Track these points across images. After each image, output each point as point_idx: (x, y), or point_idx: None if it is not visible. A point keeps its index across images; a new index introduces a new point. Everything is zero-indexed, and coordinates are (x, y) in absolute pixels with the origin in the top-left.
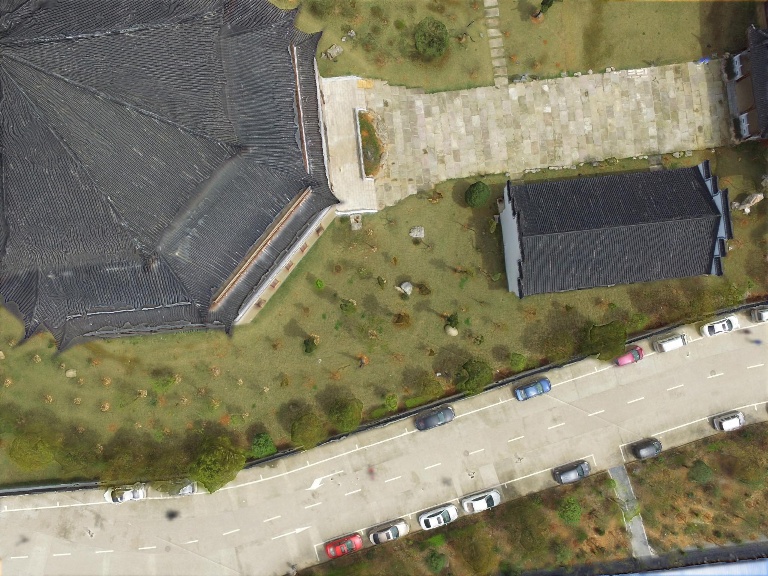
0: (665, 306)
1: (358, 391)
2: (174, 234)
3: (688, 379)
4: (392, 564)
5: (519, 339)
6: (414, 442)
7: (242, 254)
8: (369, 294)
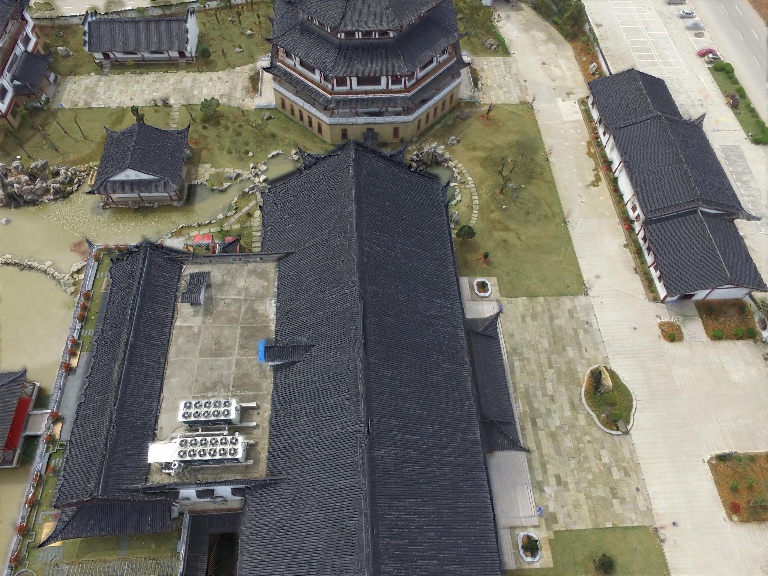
0: None
1: None
2: None
3: (124, 4)
4: None
5: (200, 18)
6: None
7: None
8: (269, 33)
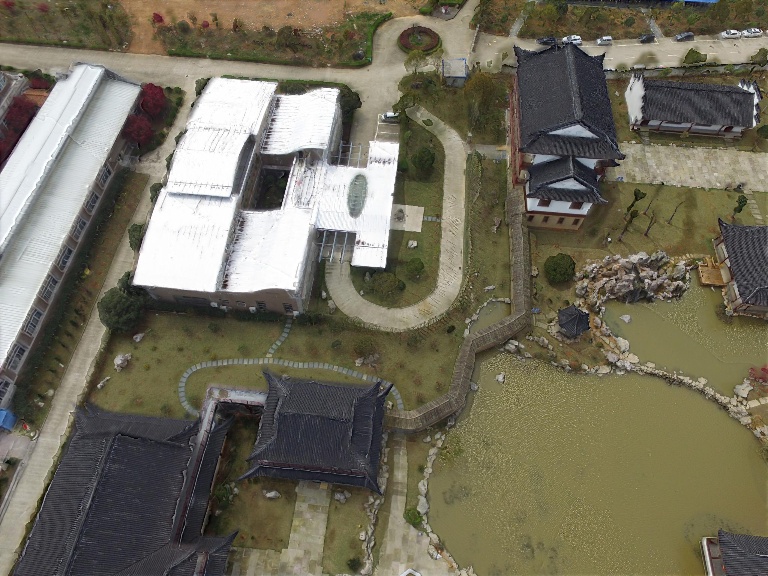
0: None
1: None
2: None
3: None
4: None
5: None
6: None
7: None
8: None
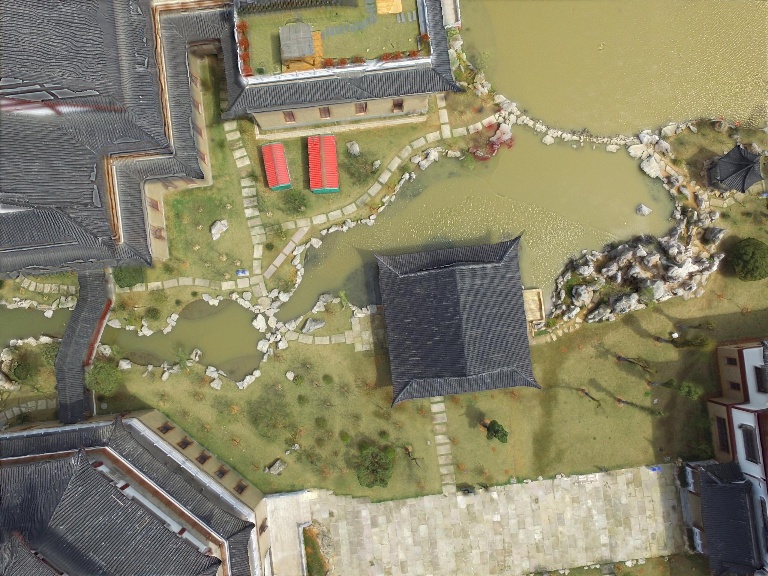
0: None
1: None
2: None
3: None
4: None
5: None
6: None
7: None
8: None
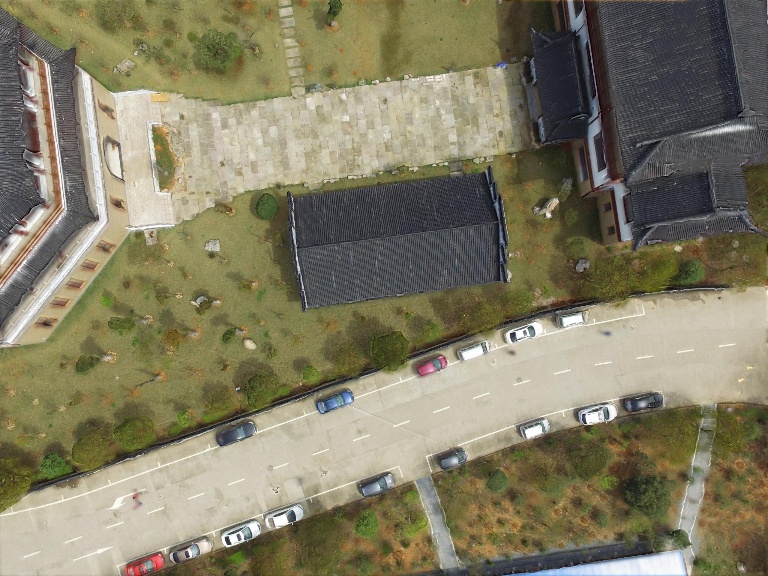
0: (468, 314)
1: (157, 408)
2: None
3: (494, 387)
4: None
5: (320, 351)
6: (217, 458)
7: None
8: (165, 309)
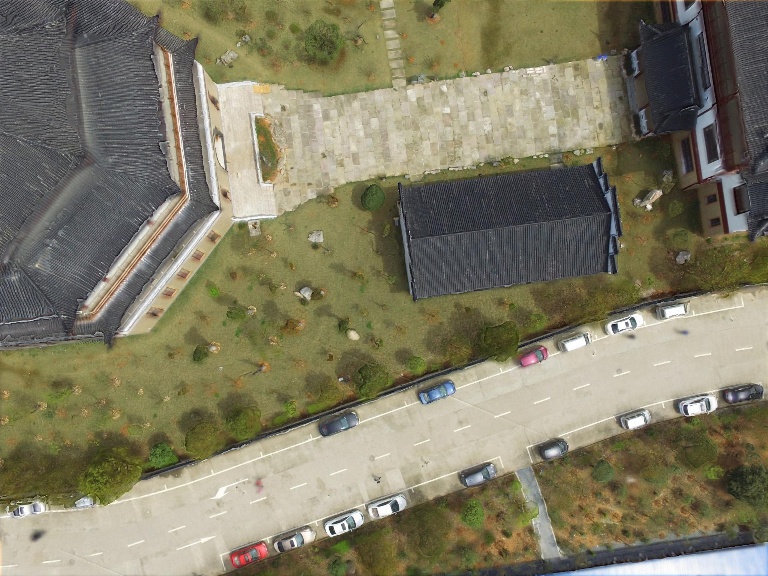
0: (569, 305)
1: (260, 398)
2: (33, 246)
3: (594, 378)
4: (298, 572)
5: (422, 342)
6: (319, 448)
7: (108, 264)
8: (269, 300)
